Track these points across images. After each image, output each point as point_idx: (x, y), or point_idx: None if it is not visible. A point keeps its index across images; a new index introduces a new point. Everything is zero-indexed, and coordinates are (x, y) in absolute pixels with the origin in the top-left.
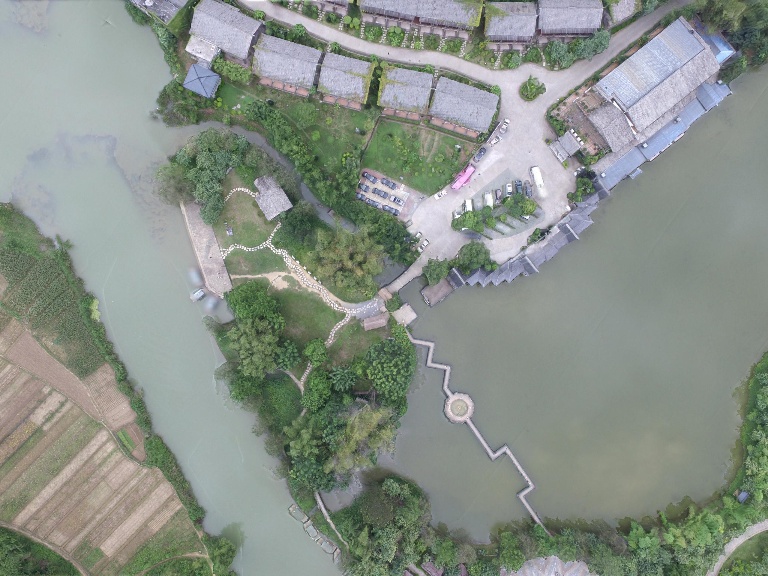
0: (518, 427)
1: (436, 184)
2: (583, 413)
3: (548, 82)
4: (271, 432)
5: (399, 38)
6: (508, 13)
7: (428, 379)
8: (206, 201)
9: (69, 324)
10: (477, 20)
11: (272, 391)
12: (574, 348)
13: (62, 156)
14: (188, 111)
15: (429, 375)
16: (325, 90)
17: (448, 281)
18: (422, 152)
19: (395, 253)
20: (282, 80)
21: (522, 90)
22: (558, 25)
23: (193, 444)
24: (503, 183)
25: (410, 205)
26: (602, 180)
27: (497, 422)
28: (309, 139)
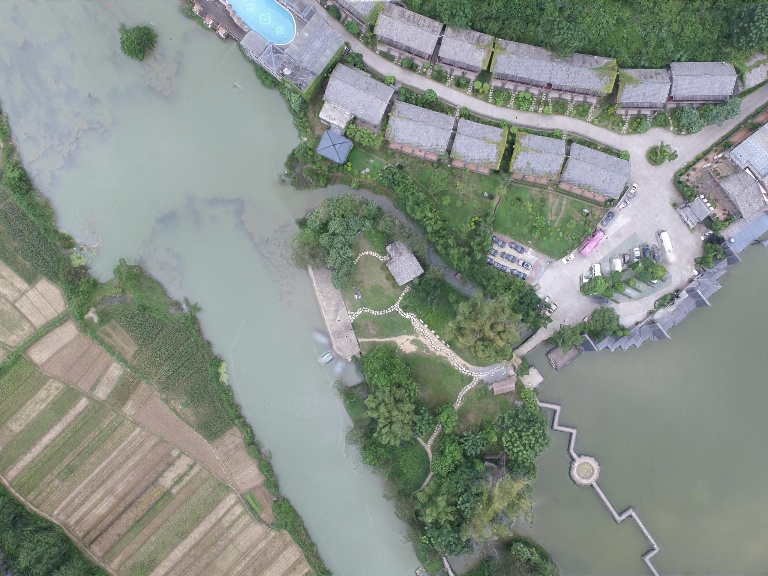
0: (643, 490)
1: (564, 248)
2: (708, 476)
3: (675, 146)
4: (400, 496)
5: (528, 103)
6: (642, 81)
7: (554, 442)
8: (339, 267)
9: (198, 387)
10: (610, 87)
11: (400, 454)
12: (699, 411)
13: (190, 219)
14: (318, 175)
15: (555, 438)
16: (458, 156)
17: (575, 345)
18: (550, 216)
19: (529, 320)
20: (415, 146)
21: (651, 155)
22: (690, 92)
23: (319, 506)
24: (630, 247)
25: (538, 269)
26: (730, 245)
27: (622, 485)
28: (438, 203)
